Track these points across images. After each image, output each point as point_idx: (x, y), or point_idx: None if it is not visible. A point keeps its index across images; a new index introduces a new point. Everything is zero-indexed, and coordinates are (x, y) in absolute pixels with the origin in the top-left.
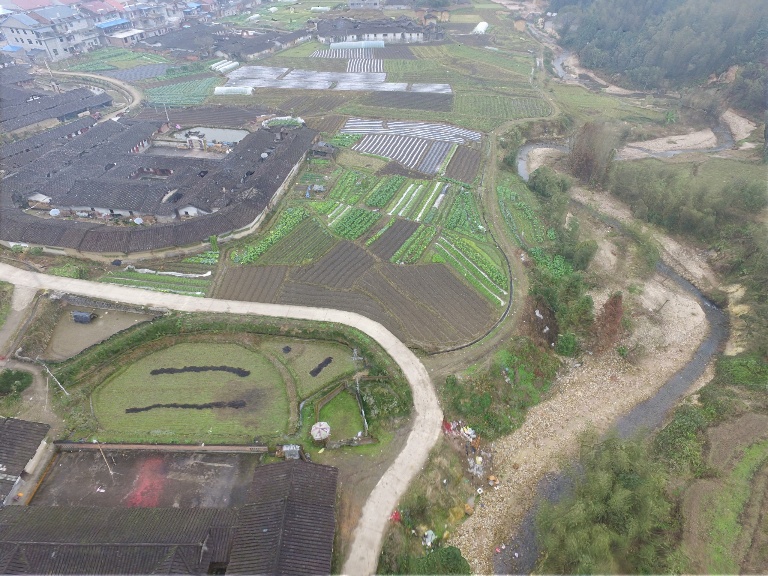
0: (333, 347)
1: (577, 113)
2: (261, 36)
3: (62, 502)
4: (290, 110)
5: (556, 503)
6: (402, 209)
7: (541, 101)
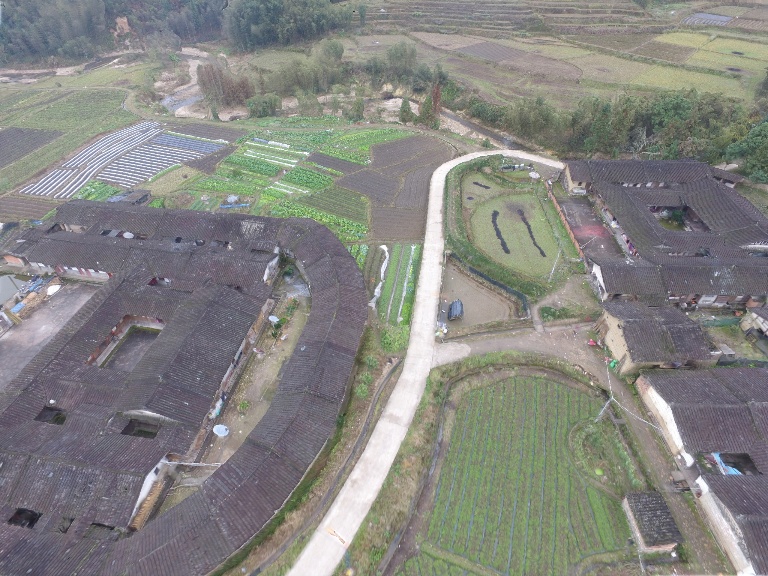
0: (464, 182)
1: None
2: None
3: None
4: None
5: (522, 149)
6: None
7: (88, 90)
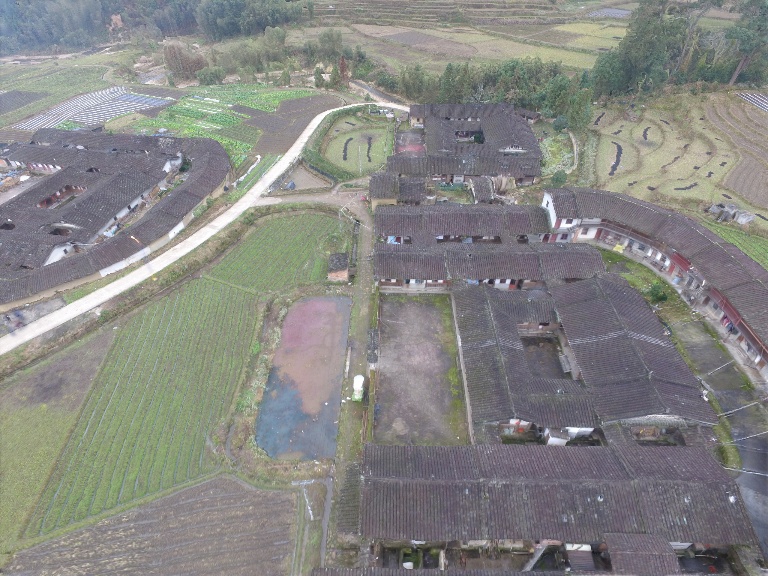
0: (339, 121)
1: (109, 64)
2: None
3: None
4: None
5: None
6: None
7: (78, 67)
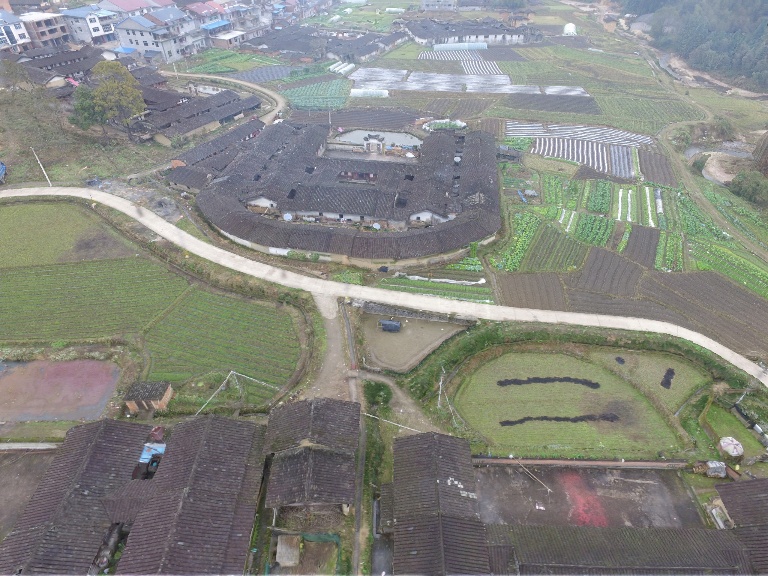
0: (666, 358)
1: (727, 116)
2: (363, 38)
3: (509, 520)
4: (447, 113)
5: None
6: (627, 215)
7: (687, 104)
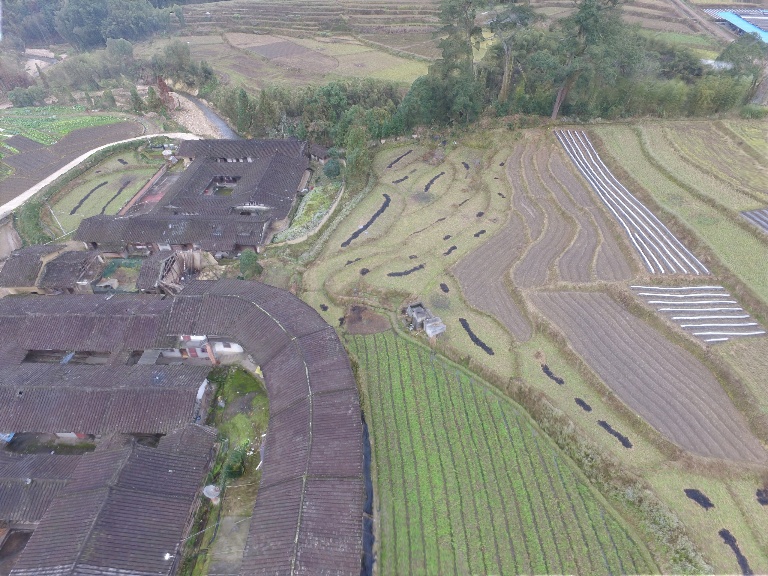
0: (111, 159)
1: None
2: None
3: None
4: None
5: None
6: None
7: None
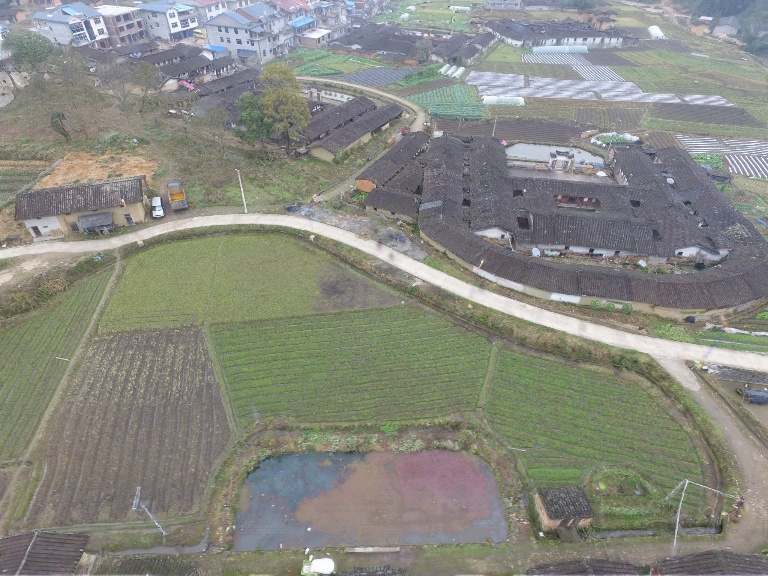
0: None
1: None
2: (457, 38)
3: None
4: (613, 125)
5: None
6: None
7: None
